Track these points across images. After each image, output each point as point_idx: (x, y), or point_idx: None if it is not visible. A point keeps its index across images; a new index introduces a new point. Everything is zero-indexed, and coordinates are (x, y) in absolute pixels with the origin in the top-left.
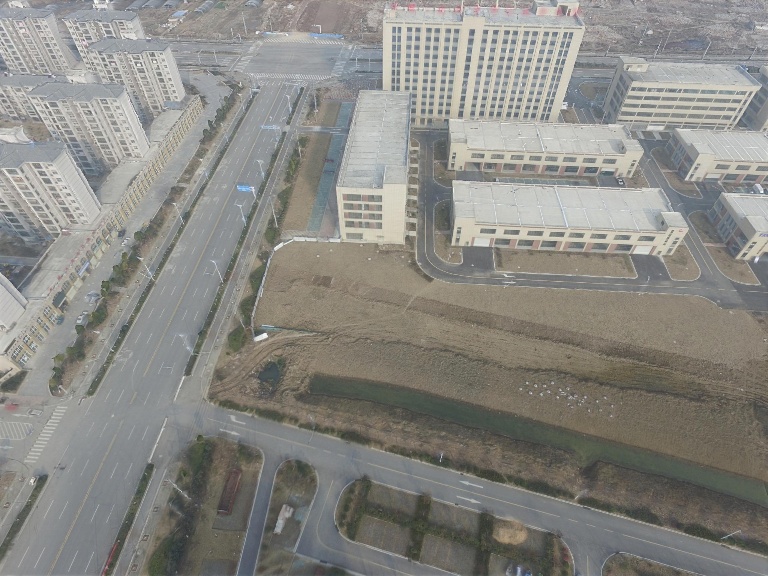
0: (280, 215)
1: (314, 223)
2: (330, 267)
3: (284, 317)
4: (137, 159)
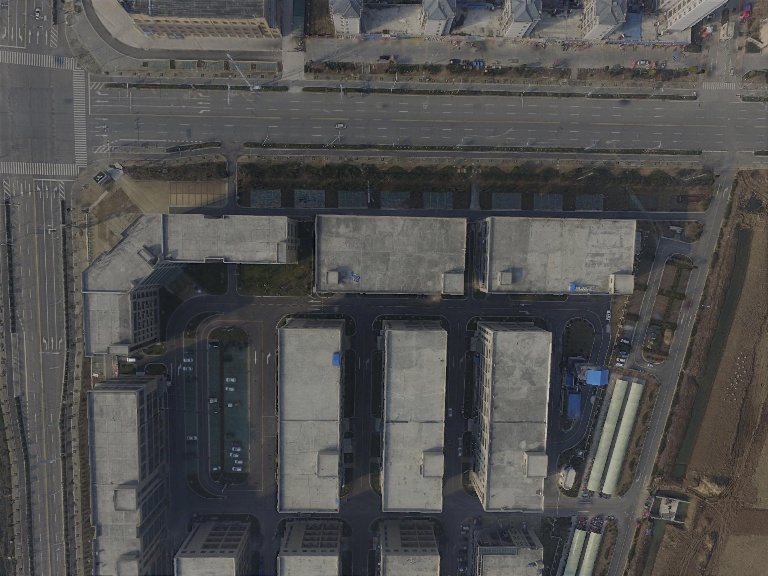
0: None
1: None
2: None
3: None
4: None
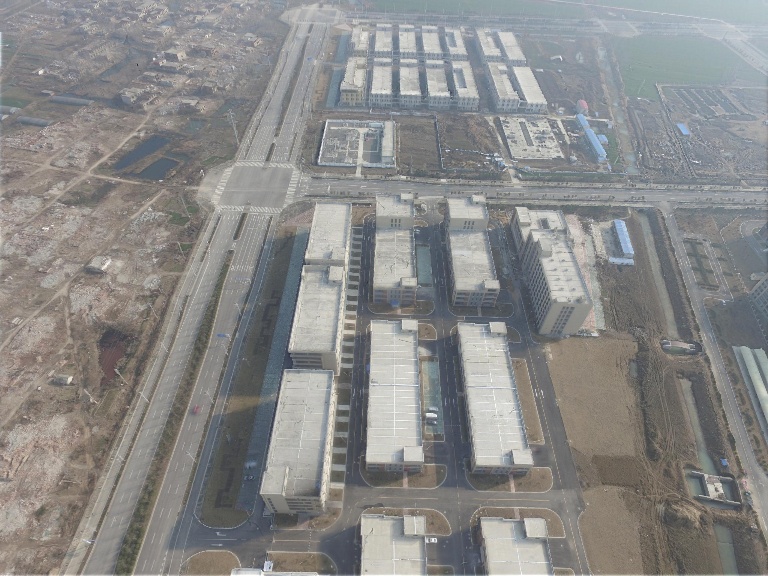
0: None
1: None
2: None
3: None
4: None
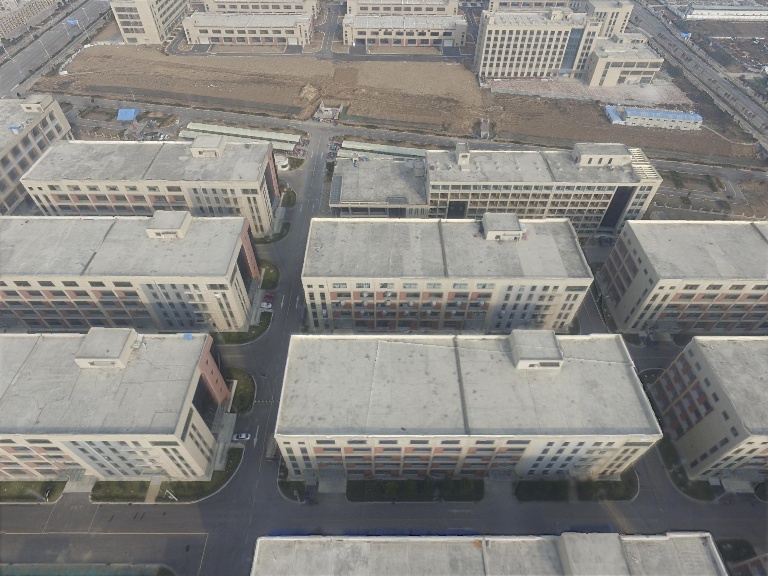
0: (93, 36)
1: (113, 38)
2: (114, 52)
3: (80, 68)
4: (8, 11)
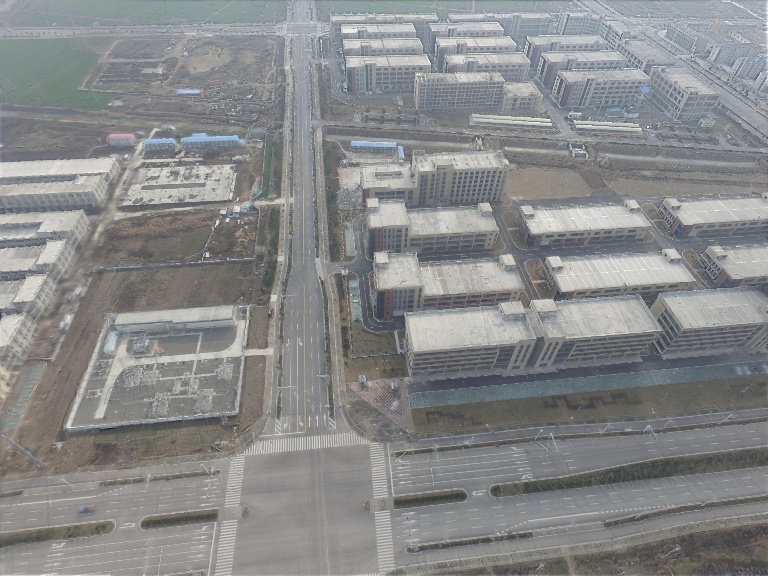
0: None
1: None
2: None
3: None
4: None
